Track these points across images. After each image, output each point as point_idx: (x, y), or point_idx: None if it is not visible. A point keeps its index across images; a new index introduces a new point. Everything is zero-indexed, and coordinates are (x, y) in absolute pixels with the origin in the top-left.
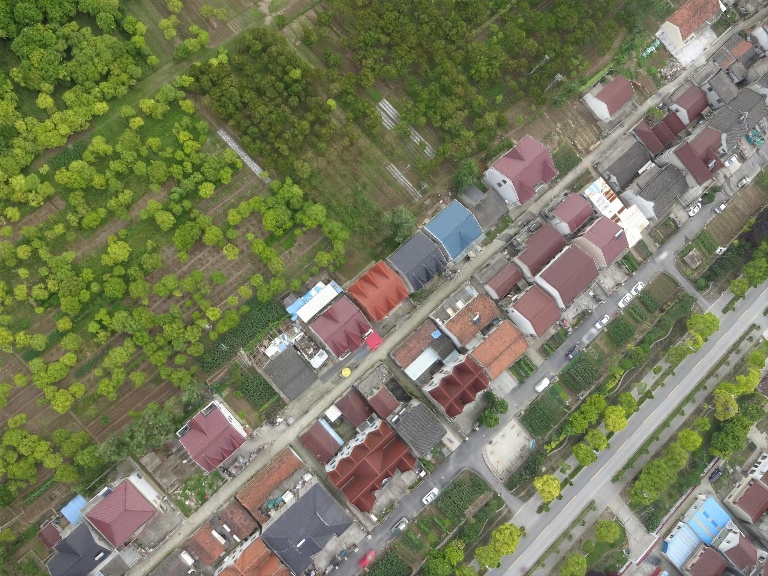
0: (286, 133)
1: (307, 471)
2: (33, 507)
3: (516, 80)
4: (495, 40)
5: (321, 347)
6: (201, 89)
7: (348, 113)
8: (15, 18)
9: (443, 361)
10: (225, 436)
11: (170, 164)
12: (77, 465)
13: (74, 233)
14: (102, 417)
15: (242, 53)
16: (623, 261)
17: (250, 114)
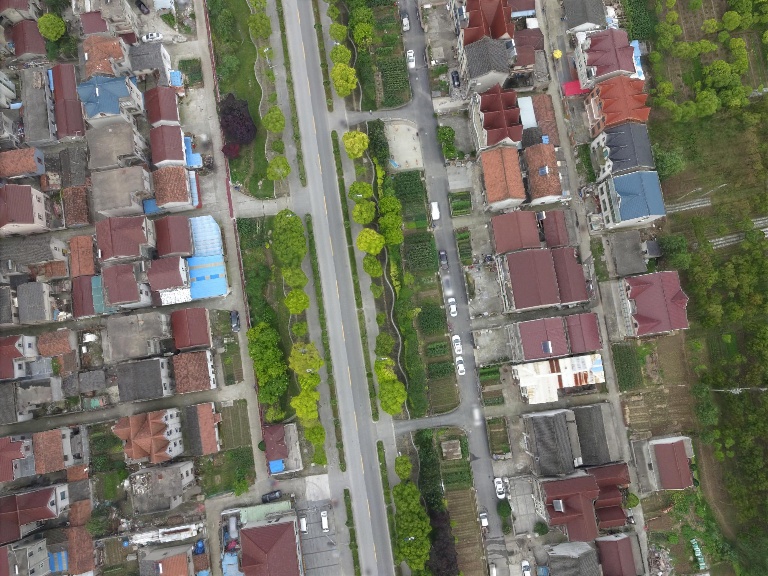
0: None
1: None
2: None
3: None
4: None
5: None
6: None
7: None
8: None
9: None
10: None
11: None
12: None
13: None
14: None
15: None
16: None
17: None
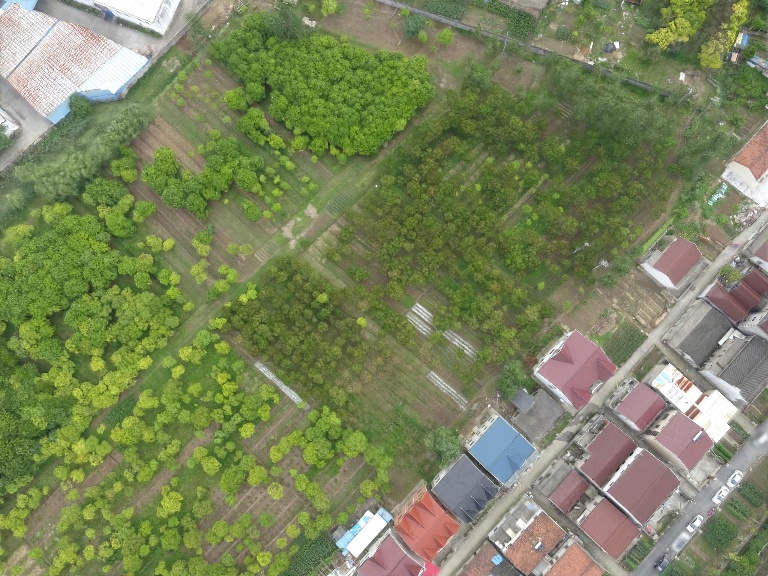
0: (318, 361)
1: None
2: None
3: (558, 262)
4: (529, 223)
5: None
6: (234, 328)
7: (379, 331)
8: (66, 293)
9: None
10: None
11: (213, 405)
12: None
13: (131, 488)
14: None
15: (271, 281)
16: (712, 450)
17: (282, 348)
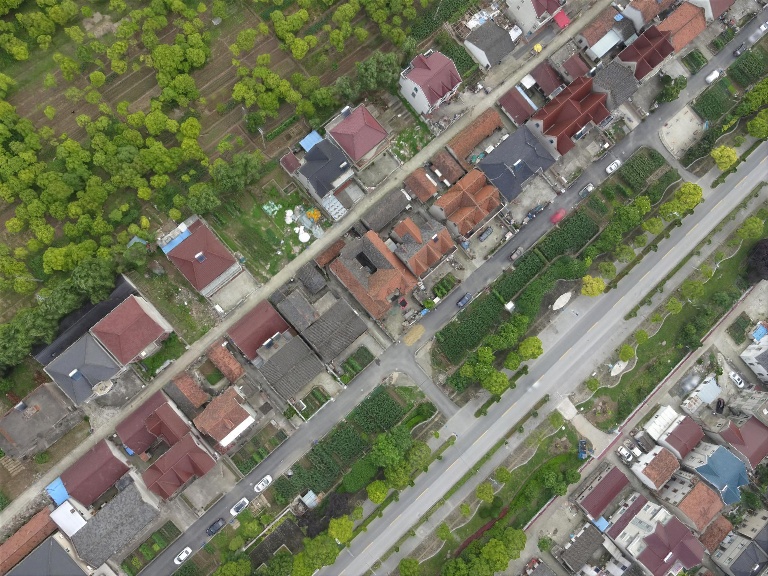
0: None
1: (504, 134)
2: (273, 144)
3: None
4: None
5: (516, 23)
6: None
7: None
8: None
9: (625, 43)
10: (446, 72)
11: None
12: (313, 103)
13: None
14: (333, 64)
15: None
16: None
17: None
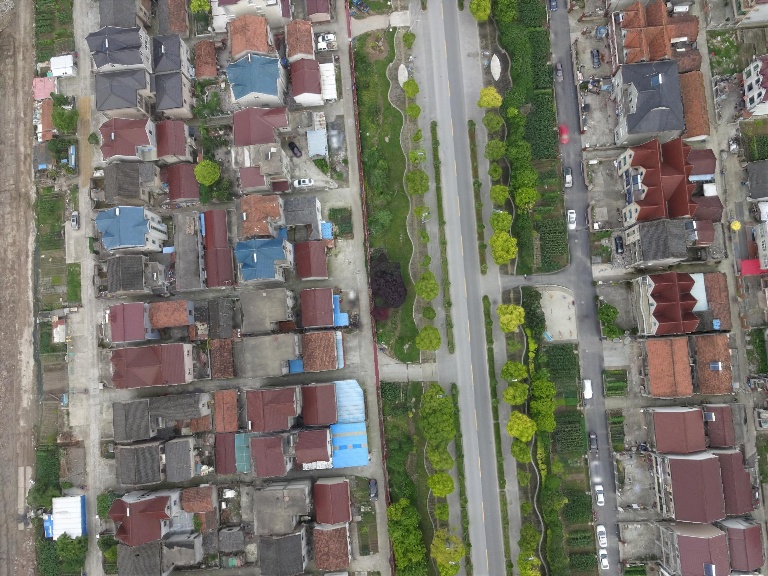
0: None
1: None
2: None
3: None
4: None
5: None
6: None
7: None
8: None
9: None
10: None
11: None
12: None
13: None
14: None
15: None
16: None
17: None
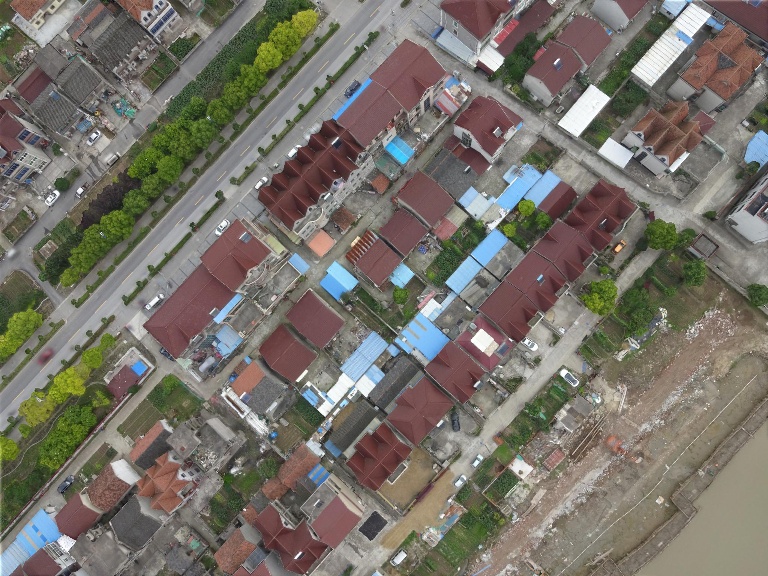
0: None
1: None
2: None
3: None
4: None
5: None
6: None
7: None
8: None
9: None
10: None
11: None
12: None
13: None
14: None
15: None
16: None
17: None
